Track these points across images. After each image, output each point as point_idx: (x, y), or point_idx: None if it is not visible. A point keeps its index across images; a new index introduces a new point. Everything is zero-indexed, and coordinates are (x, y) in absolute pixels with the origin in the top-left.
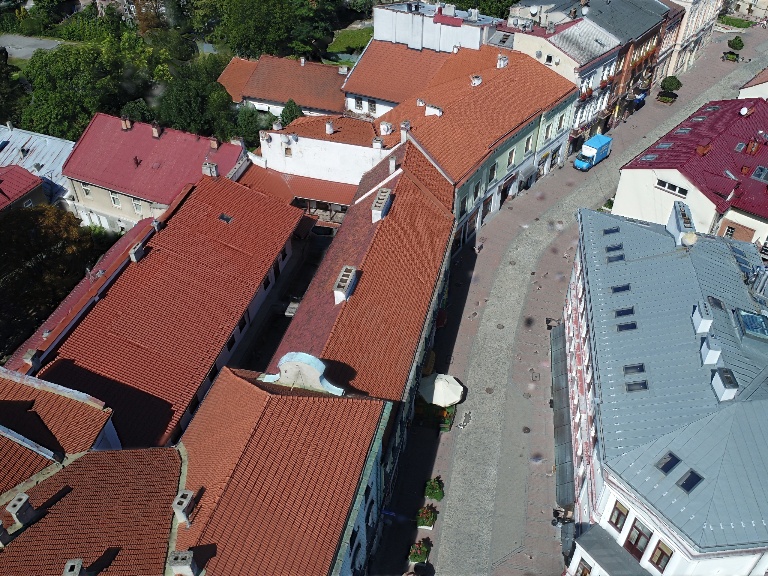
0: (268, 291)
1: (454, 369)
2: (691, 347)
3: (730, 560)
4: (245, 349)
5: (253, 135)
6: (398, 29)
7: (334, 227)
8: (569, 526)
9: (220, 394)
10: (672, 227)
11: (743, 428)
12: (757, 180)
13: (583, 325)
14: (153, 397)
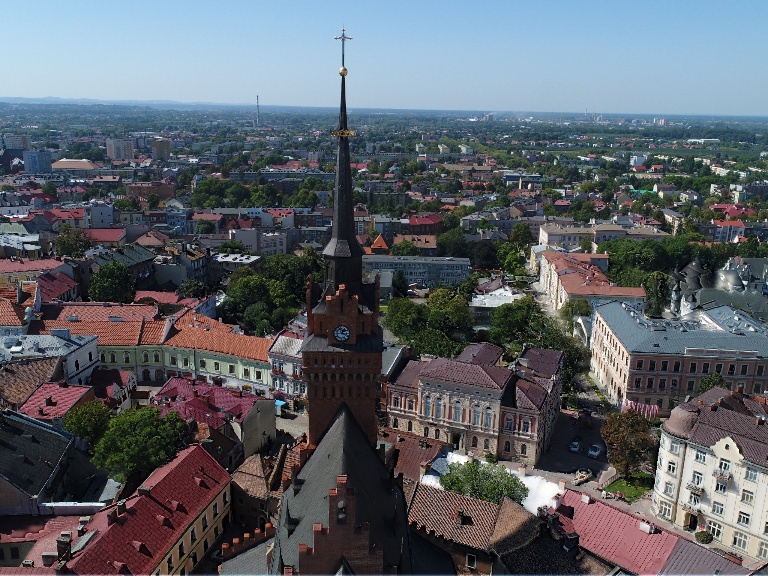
0: None
1: None
2: None
3: None
4: None
5: None
6: None
7: None
8: None
9: None
10: None
11: None
12: None
13: None
14: None
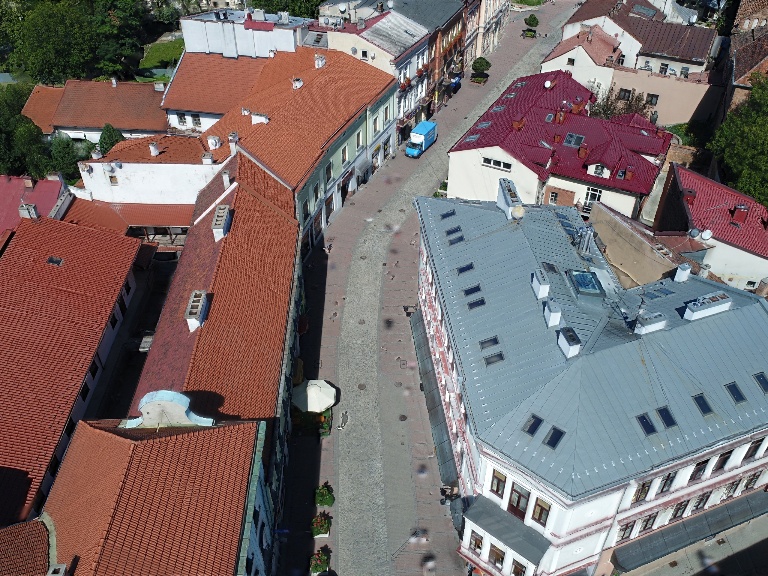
0: (117, 329)
1: (324, 372)
2: (535, 313)
3: (600, 501)
4: (102, 395)
5: (72, 166)
6: (210, 39)
7: (177, 251)
8: (457, 502)
9: (80, 451)
10: (501, 203)
11: (591, 379)
12: (569, 146)
13: (438, 308)
14: (4, 469)
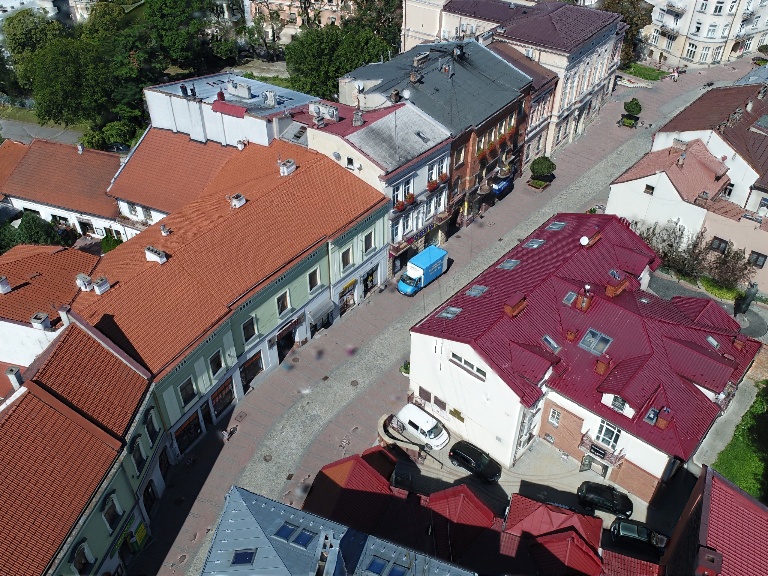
0: None
1: None
2: None
3: None
4: None
5: None
6: (177, 116)
7: None
8: None
9: None
10: None
11: None
12: (586, 350)
13: None
14: None
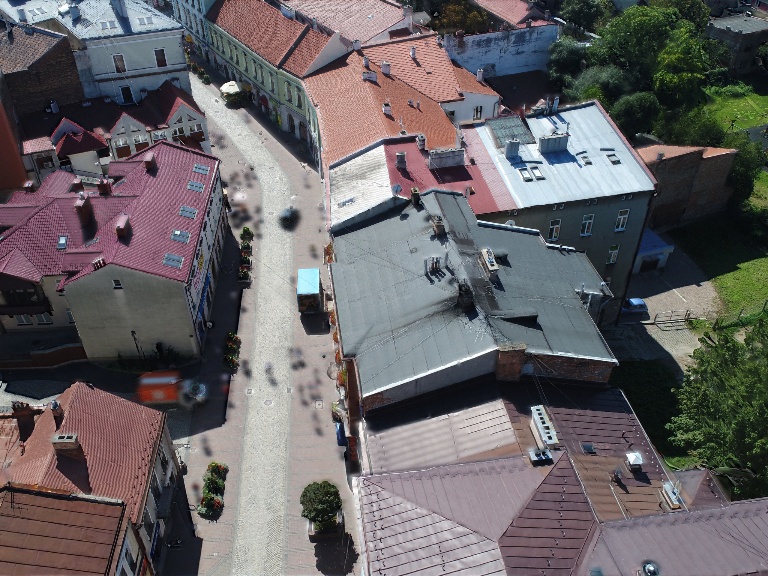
0: None
1: (243, 111)
2: None
3: None
4: None
5: None
6: None
7: None
8: None
9: None
10: None
11: None
12: None
13: None
14: None
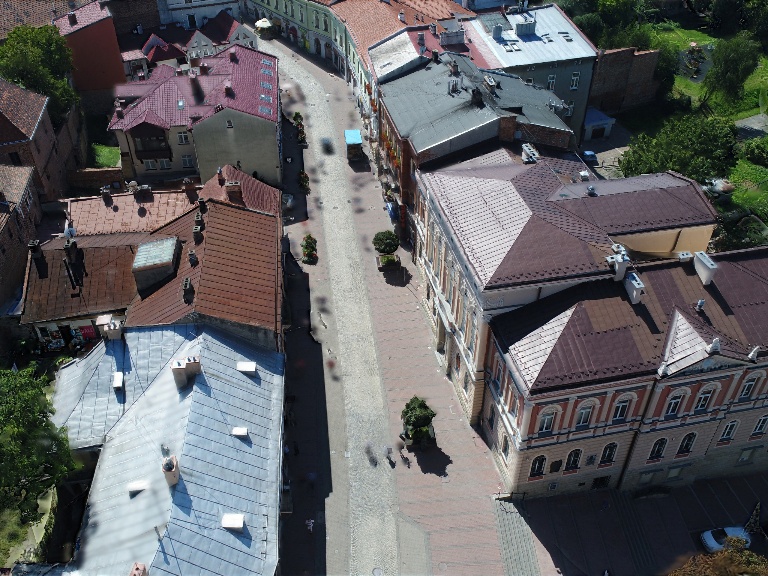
0: None
1: (275, 41)
2: None
3: None
4: None
5: None
6: None
7: None
8: None
9: None
10: None
11: None
12: None
13: None
14: None
